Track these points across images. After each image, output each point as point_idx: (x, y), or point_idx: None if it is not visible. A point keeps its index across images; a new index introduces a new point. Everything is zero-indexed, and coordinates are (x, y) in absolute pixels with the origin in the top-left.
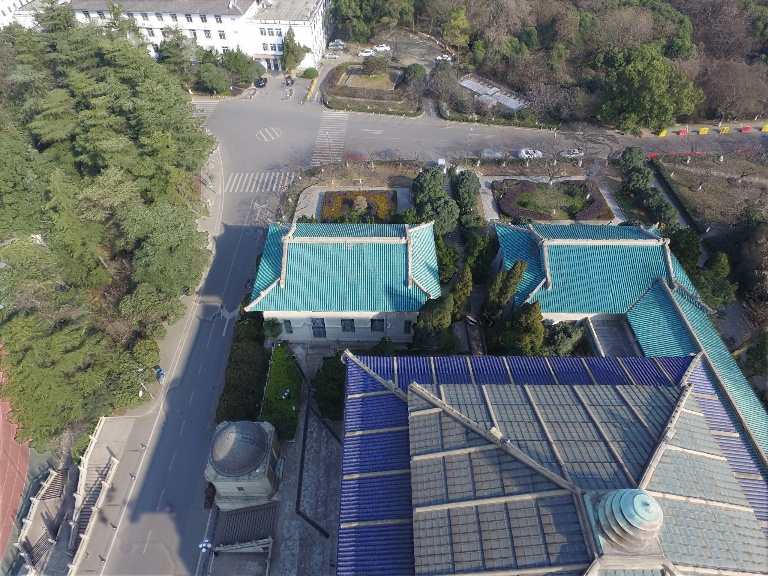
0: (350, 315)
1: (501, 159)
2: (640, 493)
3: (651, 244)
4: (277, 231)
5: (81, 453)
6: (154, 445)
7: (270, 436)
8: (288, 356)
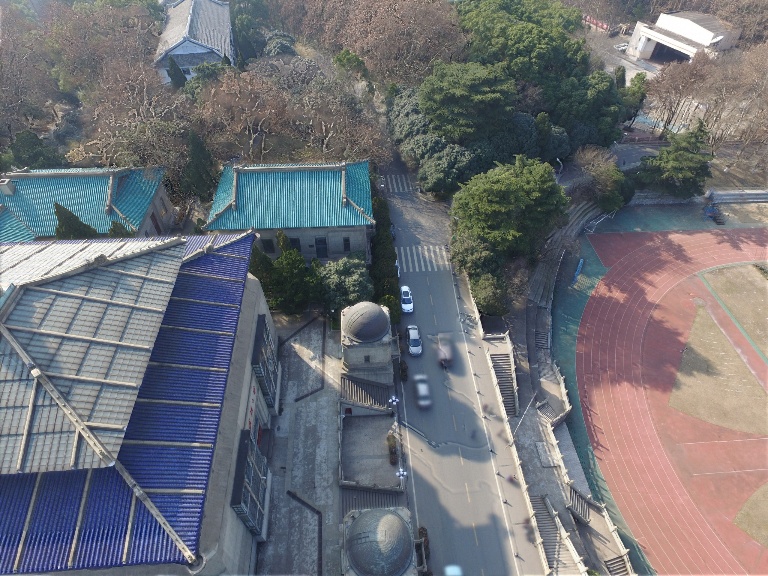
0: None
1: None
2: None
3: None
4: None
5: None
6: None
7: (347, 566)
8: None
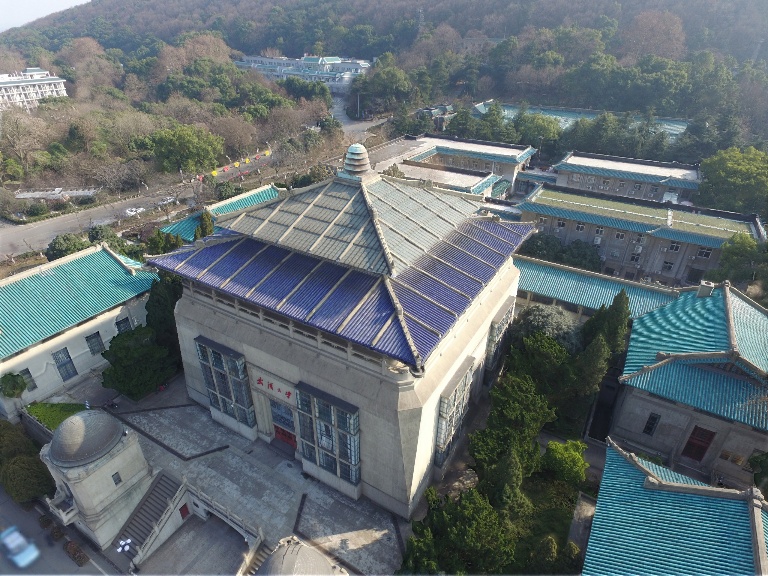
0: (93, 328)
1: (113, 222)
2: None
3: (266, 189)
4: None
5: None
6: None
7: None
8: (51, 404)
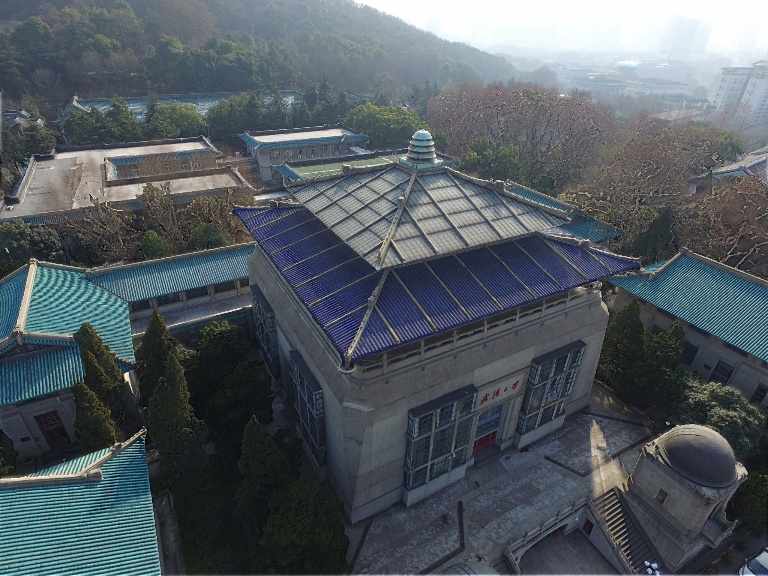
0: None
1: None
2: (417, 132)
3: (35, 271)
4: None
5: None
6: None
7: None
8: None
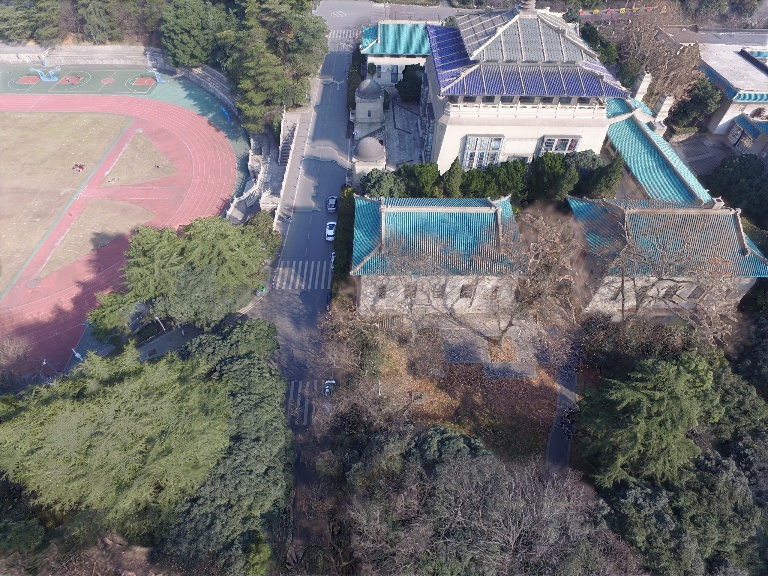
0: (412, 63)
1: None
2: None
3: None
4: (369, 29)
5: (279, 122)
6: (314, 121)
7: None
8: None
